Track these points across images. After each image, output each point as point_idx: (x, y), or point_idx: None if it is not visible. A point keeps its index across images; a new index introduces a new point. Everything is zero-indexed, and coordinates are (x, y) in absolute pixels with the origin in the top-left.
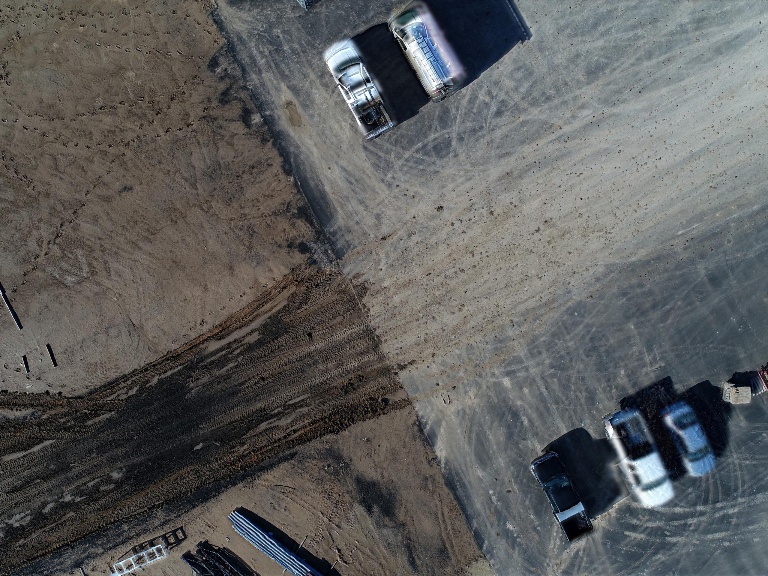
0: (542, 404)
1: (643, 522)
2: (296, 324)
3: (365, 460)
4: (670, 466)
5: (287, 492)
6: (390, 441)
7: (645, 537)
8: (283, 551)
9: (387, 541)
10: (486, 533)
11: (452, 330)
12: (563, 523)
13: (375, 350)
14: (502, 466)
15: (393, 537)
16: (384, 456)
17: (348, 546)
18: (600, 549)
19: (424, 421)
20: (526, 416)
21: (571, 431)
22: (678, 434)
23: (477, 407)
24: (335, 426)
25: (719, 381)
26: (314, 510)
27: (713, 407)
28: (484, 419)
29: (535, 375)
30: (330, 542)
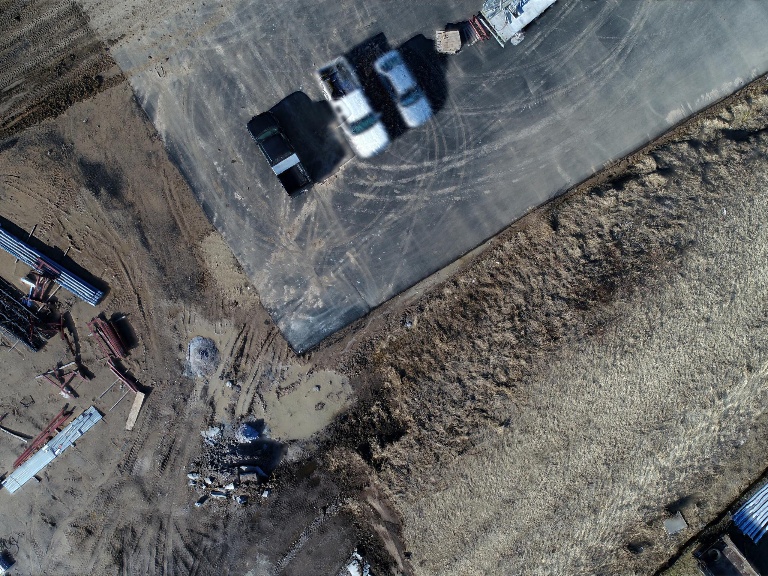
0: (258, 70)
1: (372, 182)
2: (4, 9)
3: (87, 142)
4: (393, 123)
5: (12, 181)
6: (110, 120)
7: (375, 197)
8: (10, 238)
9: (118, 224)
10: (215, 205)
11: (159, 1)
12: (281, 178)
13: (83, 27)
14: (224, 136)
15: (124, 219)
16: (105, 136)
17: (79, 232)
18: (331, 213)
19: (141, 96)
20: (243, 83)
21: (289, 95)
22: (397, 91)
23: (192, 78)
24: (53, 109)
25: (433, 34)
26: (41, 198)
27: (429, 61)
28: (201, 89)
29: (247, 41)
30: (61, 229)
